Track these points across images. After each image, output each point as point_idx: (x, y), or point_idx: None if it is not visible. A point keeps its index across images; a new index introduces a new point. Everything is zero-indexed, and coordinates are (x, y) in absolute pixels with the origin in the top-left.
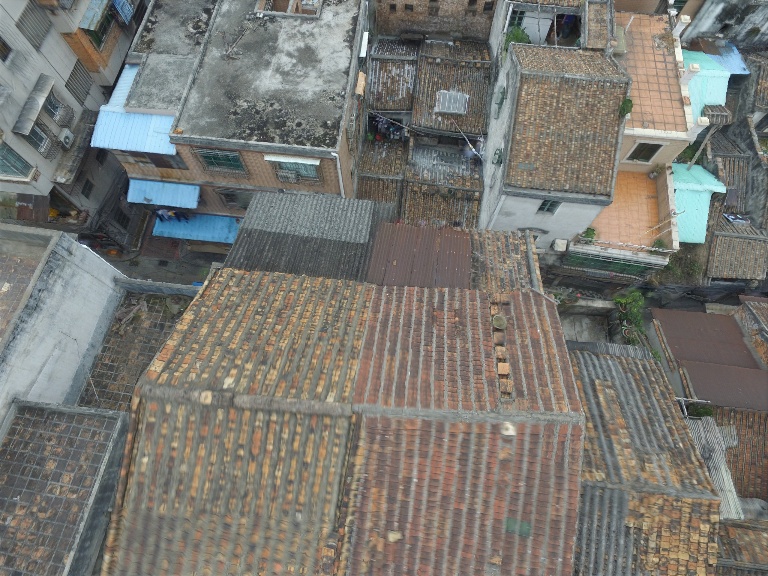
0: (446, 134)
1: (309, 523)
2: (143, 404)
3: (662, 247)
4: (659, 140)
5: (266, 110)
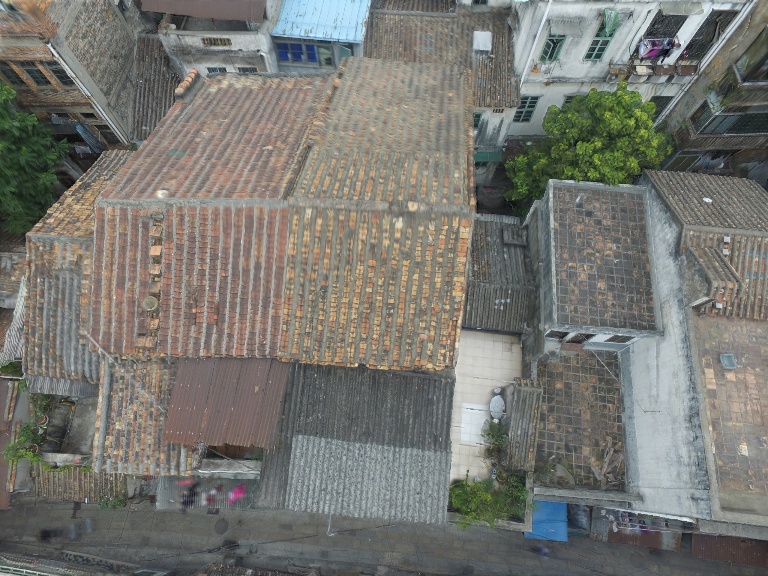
0: None
1: (328, 150)
2: (466, 202)
3: None
4: None
5: None
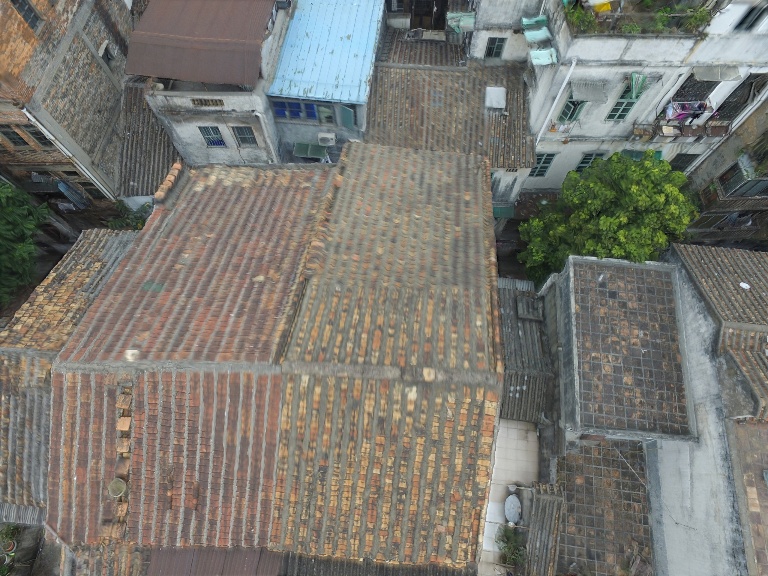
0: None
1: (329, 284)
2: (492, 367)
3: None
4: None
5: None
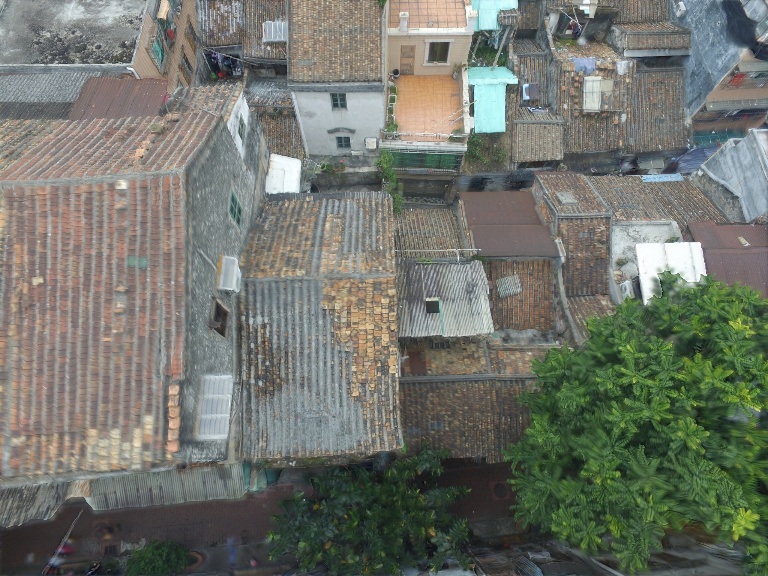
0: (277, 62)
1: None
2: None
3: (457, 134)
4: (444, 38)
5: (68, 37)
